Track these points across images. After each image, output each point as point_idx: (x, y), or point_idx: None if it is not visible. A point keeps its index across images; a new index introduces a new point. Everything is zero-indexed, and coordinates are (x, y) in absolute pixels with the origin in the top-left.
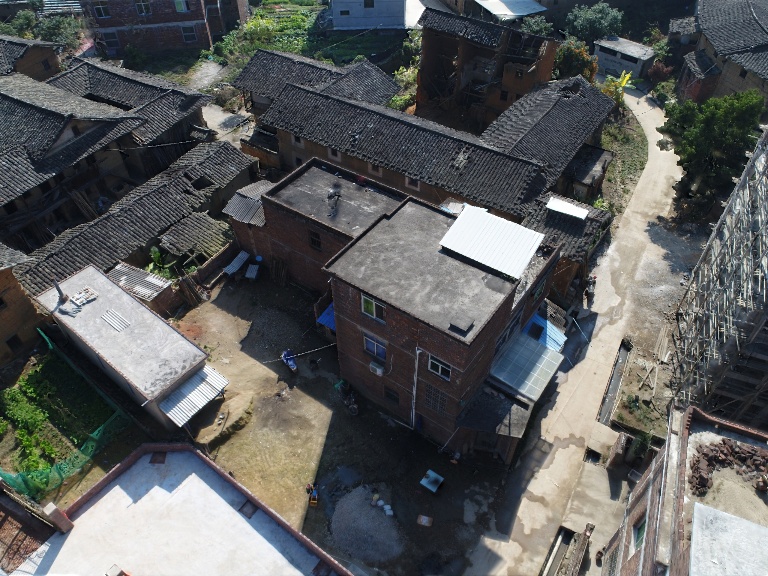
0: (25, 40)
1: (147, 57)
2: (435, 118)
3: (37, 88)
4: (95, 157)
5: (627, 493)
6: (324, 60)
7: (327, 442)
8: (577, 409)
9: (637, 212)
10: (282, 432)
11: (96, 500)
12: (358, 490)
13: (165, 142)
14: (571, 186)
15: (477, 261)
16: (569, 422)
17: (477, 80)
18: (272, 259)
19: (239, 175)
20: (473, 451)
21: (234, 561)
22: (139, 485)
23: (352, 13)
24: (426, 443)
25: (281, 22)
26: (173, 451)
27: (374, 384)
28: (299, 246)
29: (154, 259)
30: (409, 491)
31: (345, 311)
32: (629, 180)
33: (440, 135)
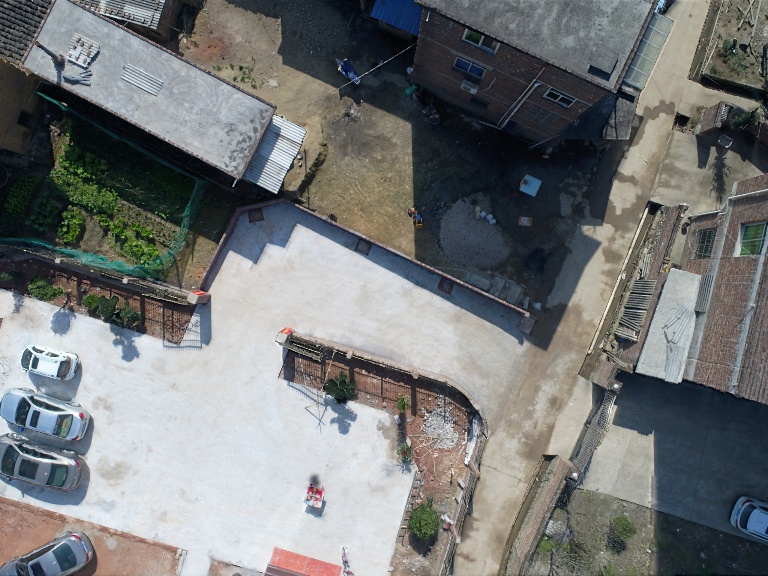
0: None
1: None
2: None
3: None
4: None
5: (714, 159)
6: None
7: (415, 160)
8: (669, 68)
9: None
10: (365, 158)
11: (218, 268)
12: (459, 206)
13: None
14: None
15: None
16: (660, 86)
17: None
18: None
19: None
20: (564, 142)
21: (367, 294)
22: (251, 246)
23: None
24: (515, 141)
25: None
26: (267, 206)
27: (458, 93)
28: None
29: None
30: (506, 196)
31: (437, 36)
32: None
33: None
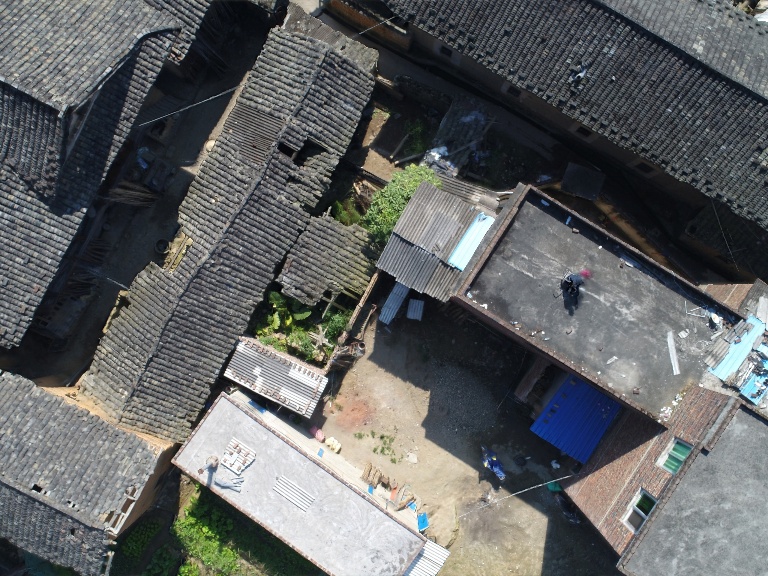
0: None
1: None
2: None
3: None
4: None
5: None
6: None
7: (546, 555)
8: None
9: None
10: (495, 545)
11: None
12: None
13: None
14: None
15: None
16: None
17: None
18: None
19: None
20: None
21: None
22: None
23: None
24: None
25: None
26: None
27: None
28: None
29: (278, 309)
30: None
31: None
32: None
33: (746, 92)
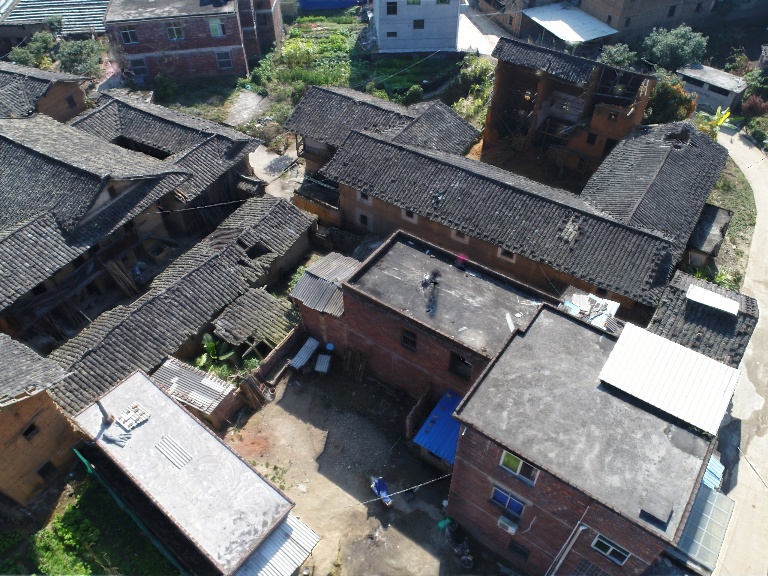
0: (47, 73)
1: (179, 87)
2: (507, 160)
3: (63, 134)
4: (133, 219)
5: None
6: (377, 91)
7: None
8: (742, 559)
9: (759, 281)
10: None
11: None
12: None
13: (208, 194)
14: (686, 253)
15: (654, 406)
16: None
17: (553, 117)
18: (347, 349)
19: (298, 238)
20: None
21: None
22: None
23: (400, 35)
24: None
25: (320, 43)
26: None
27: (495, 534)
28: (386, 342)
29: (207, 349)
30: None
31: (473, 459)
32: (740, 239)
33: (542, 199)
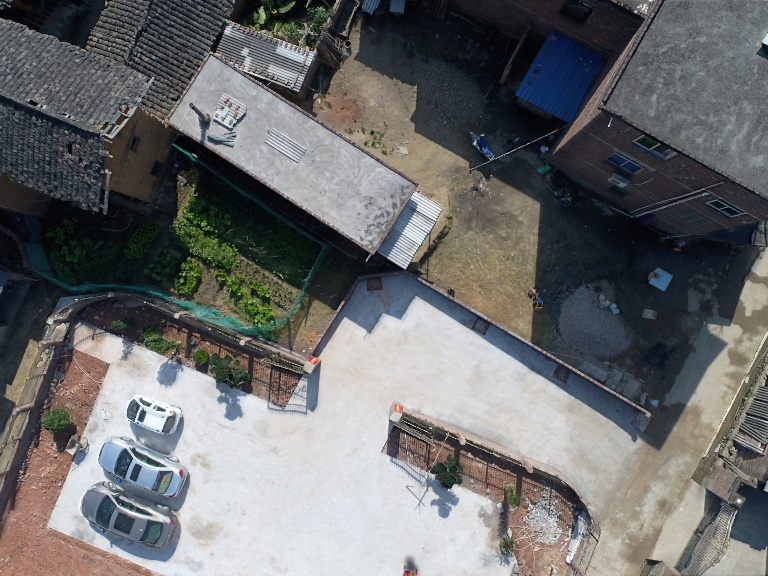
0: None
1: None
2: None
3: None
4: None
5: None
6: None
7: (540, 241)
8: None
9: None
10: (489, 234)
11: (331, 334)
12: (582, 292)
13: None
14: None
15: None
16: None
17: None
18: None
19: None
20: None
21: (480, 375)
22: (366, 315)
23: None
24: (647, 231)
25: None
26: (387, 276)
27: (598, 180)
28: None
29: (263, 1)
30: (632, 286)
31: (603, 135)
32: None
33: None
